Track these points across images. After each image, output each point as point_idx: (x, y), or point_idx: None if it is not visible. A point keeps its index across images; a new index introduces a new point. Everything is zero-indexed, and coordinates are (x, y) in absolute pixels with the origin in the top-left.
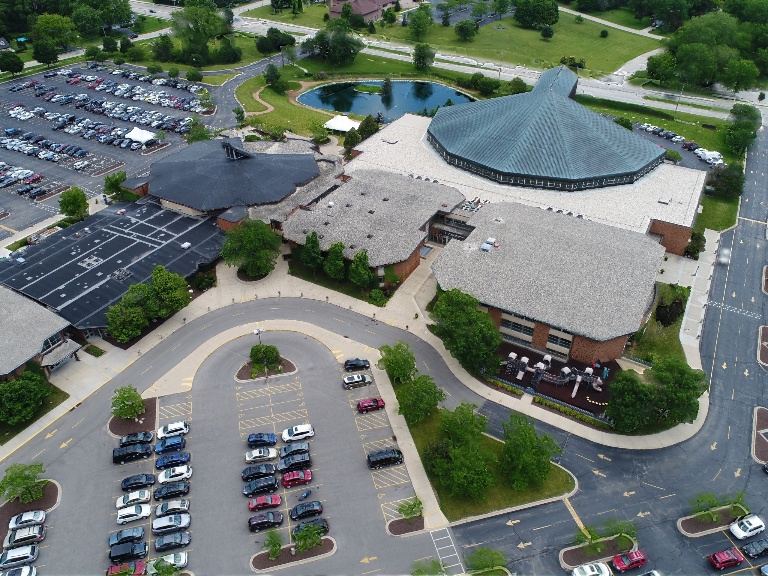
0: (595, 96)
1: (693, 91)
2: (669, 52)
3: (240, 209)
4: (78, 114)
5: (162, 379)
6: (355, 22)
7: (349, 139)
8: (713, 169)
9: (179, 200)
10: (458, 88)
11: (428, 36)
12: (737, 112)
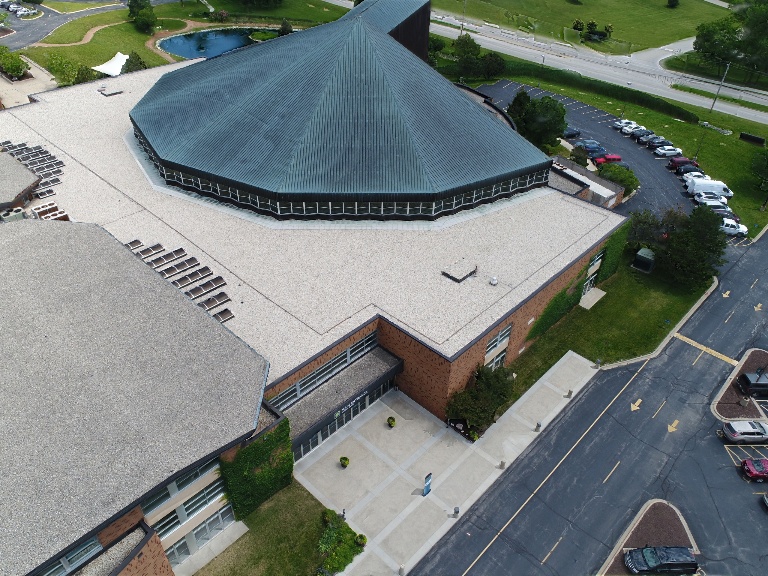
0: (592, 76)
1: (742, 76)
2: (734, 18)
3: None
4: None
5: None
6: None
7: None
8: (661, 214)
9: None
10: None
11: None
12: None
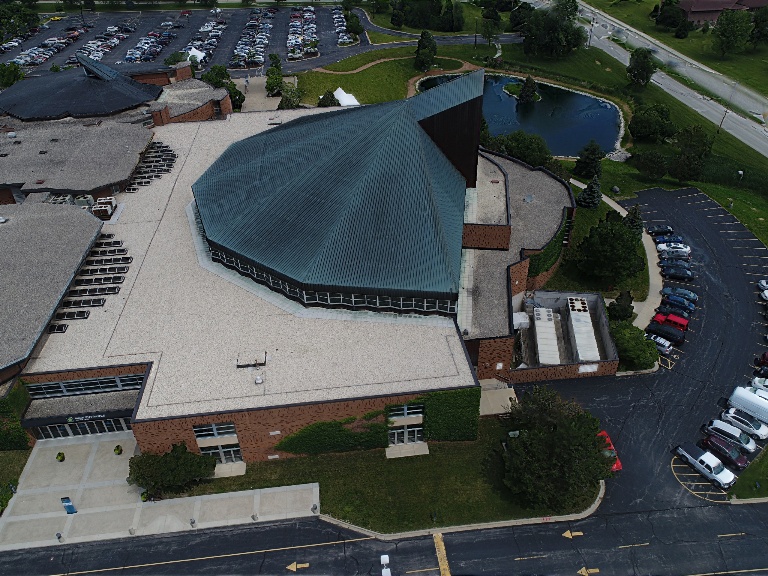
0: None
1: None
2: None
3: None
4: (232, 36)
5: None
6: (664, 17)
7: (277, 109)
8: None
9: (4, 92)
10: (628, 121)
11: (755, 55)
12: None
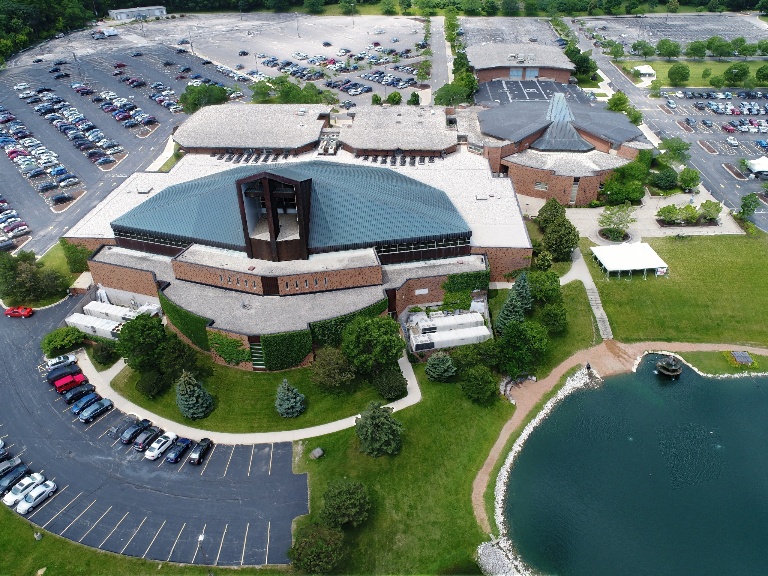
0: None
1: None
2: None
3: (492, 105)
4: None
5: (429, 92)
6: None
7: None
8: None
9: None
10: None
11: None
12: None
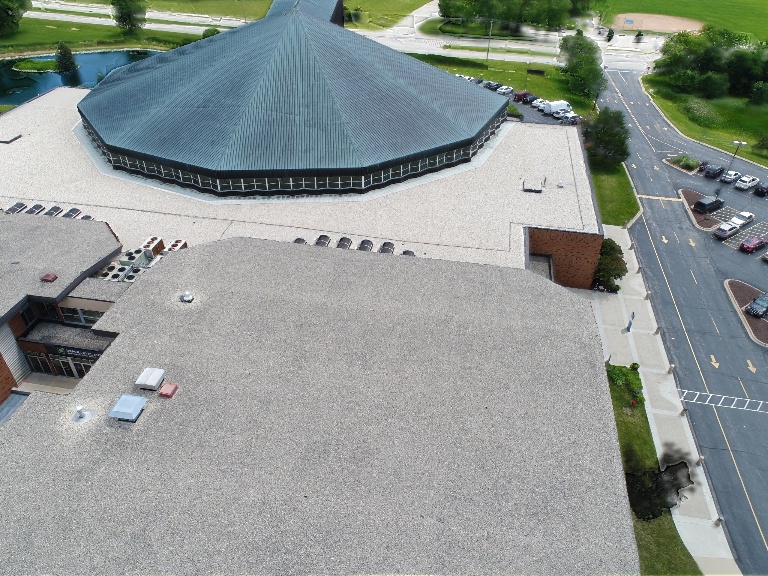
0: None
1: (505, 29)
2: None
3: None
4: None
5: None
6: None
7: None
8: (578, 123)
9: None
10: None
11: None
12: (570, 47)
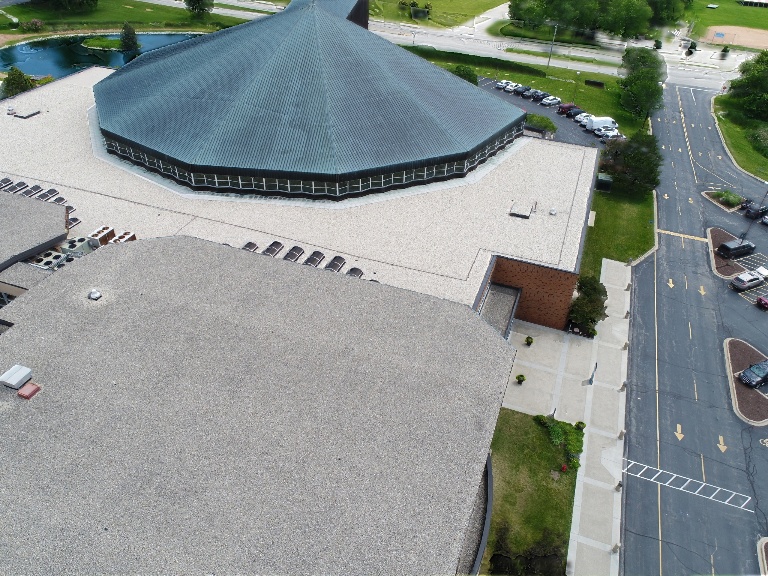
0: (440, 49)
1: (569, 35)
2: None
3: None
4: None
5: None
6: None
7: None
8: (607, 144)
9: None
10: None
11: None
12: (632, 59)
